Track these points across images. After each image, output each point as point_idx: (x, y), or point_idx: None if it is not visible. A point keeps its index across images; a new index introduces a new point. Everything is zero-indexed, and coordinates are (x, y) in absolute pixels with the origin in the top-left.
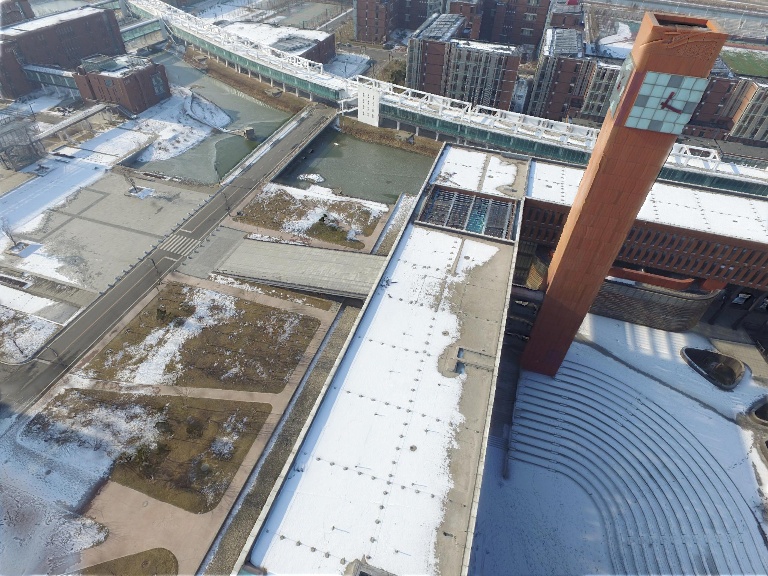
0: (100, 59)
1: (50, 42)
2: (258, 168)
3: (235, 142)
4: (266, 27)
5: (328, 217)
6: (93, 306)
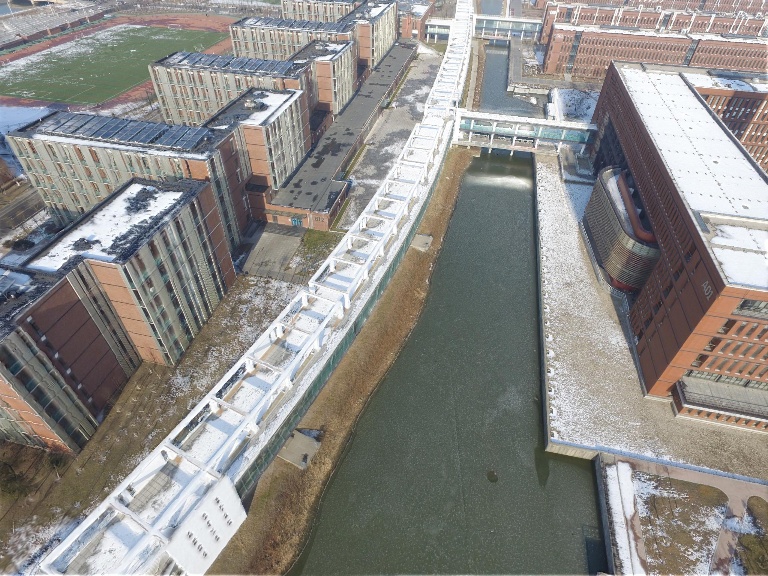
0: None
1: None
2: None
3: None
4: None
5: None
6: None
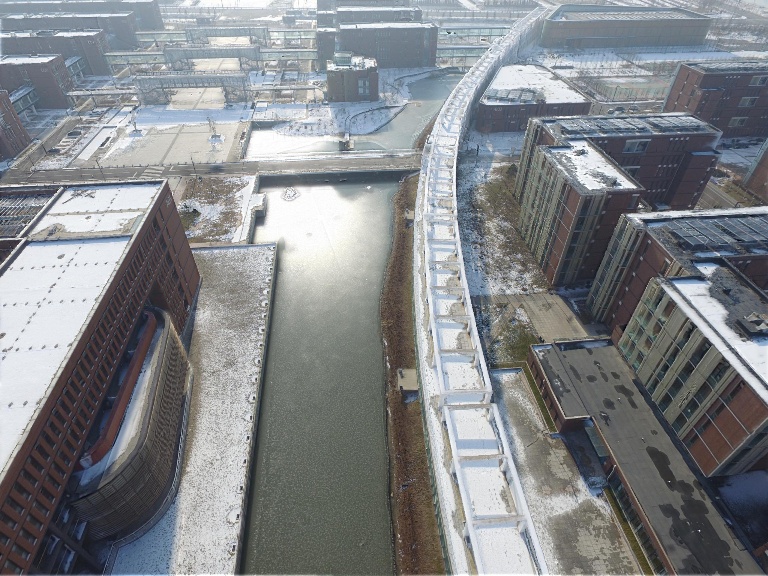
0: (344, 55)
1: (366, 40)
2: (279, 165)
3: (330, 146)
4: (543, 76)
5: (210, 215)
6: (81, 170)
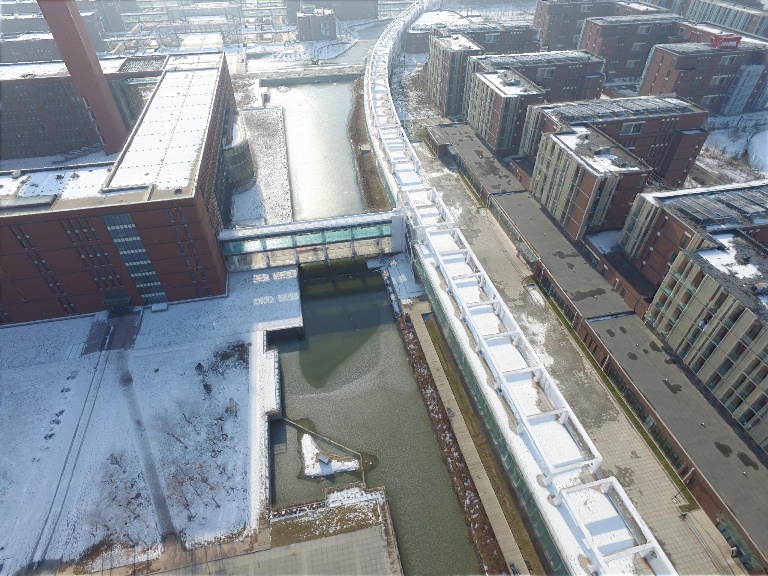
0: None
1: None
2: (272, 74)
3: None
4: (453, 17)
5: (235, 97)
6: None
